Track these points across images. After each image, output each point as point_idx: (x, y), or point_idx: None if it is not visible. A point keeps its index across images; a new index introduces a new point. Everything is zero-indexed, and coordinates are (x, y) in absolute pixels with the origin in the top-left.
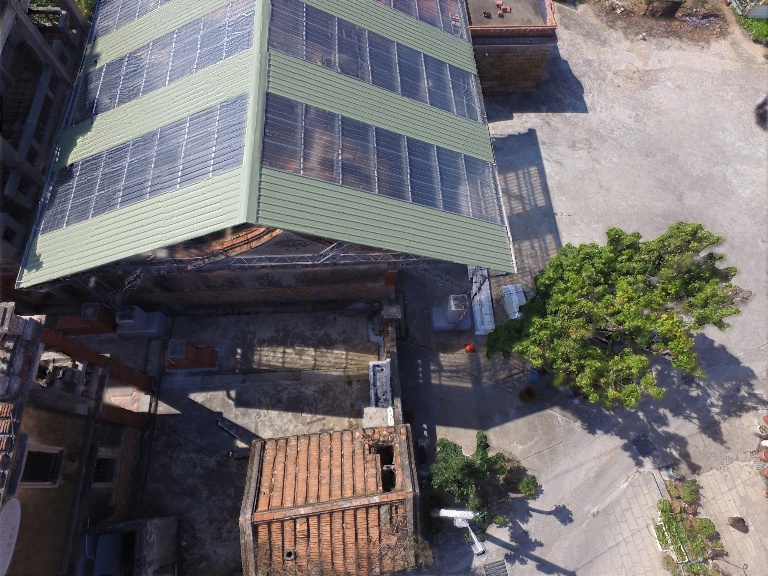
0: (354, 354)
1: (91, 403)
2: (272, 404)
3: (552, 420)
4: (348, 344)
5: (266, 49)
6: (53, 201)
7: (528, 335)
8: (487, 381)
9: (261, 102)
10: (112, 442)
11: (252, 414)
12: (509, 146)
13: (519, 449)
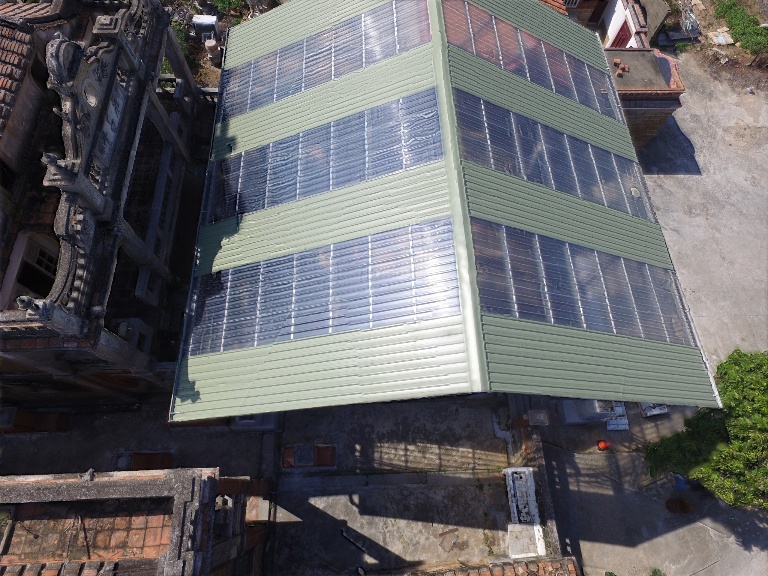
0: (481, 452)
1: (238, 540)
2: (399, 511)
3: (704, 535)
4: (474, 440)
5: (459, 162)
6: (201, 315)
7: (709, 462)
8: (629, 488)
9: (467, 231)
10: (248, 571)
11: (379, 523)
12: None
13: (672, 570)
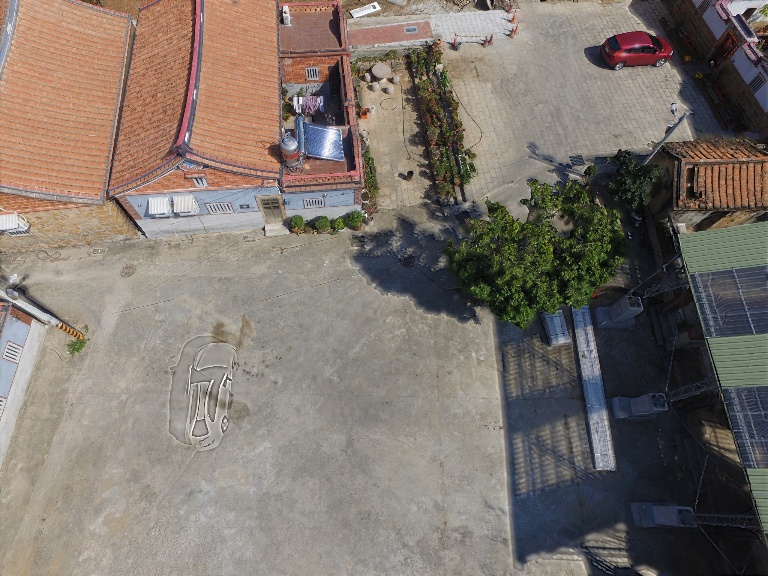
0: None
1: None
2: None
3: None
4: None
5: None
6: None
7: None
8: None
9: None
10: None
11: None
12: (551, 538)
13: None
